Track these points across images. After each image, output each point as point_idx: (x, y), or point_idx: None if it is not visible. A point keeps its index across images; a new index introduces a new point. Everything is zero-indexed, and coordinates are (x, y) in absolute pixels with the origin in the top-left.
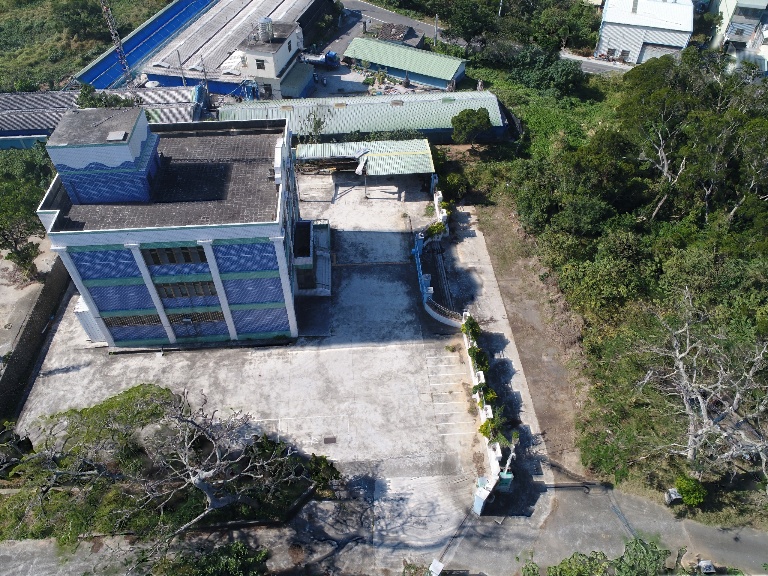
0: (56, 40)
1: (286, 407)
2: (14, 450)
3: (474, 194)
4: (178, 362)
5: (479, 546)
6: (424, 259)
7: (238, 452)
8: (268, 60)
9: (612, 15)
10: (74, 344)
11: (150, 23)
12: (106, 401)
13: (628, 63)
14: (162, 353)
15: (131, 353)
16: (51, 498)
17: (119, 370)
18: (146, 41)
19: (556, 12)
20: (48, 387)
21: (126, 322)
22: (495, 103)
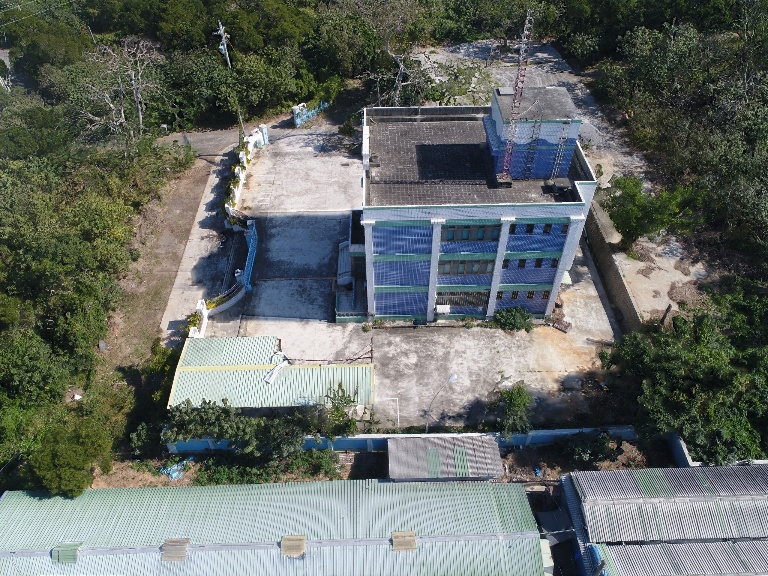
0: None
1: None
2: None
3: (137, 383)
4: None
5: (271, 135)
6: None
7: None
8: None
9: None
10: None
11: None
12: None
13: None
14: None
15: None
16: None
17: None
18: None
19: None
20: None
21: None
22: None
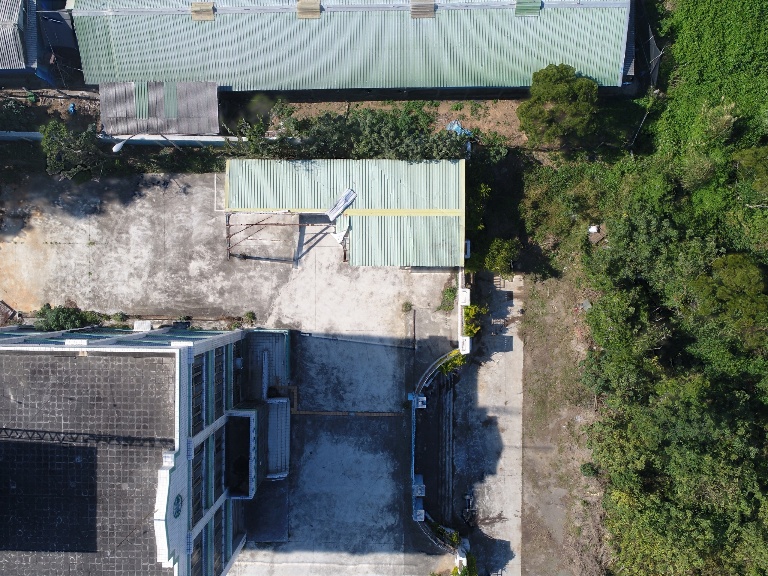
0: None
1: None
2: None
3: (529, 250)
4: None
5: None
6: (425, 410)
7: None
8: None
9: None
10: None
11: None
12: None
13: None
14: None
15: None
16: None
17: None
18: None
19: None
20: None
21: None
22: (623, 21)
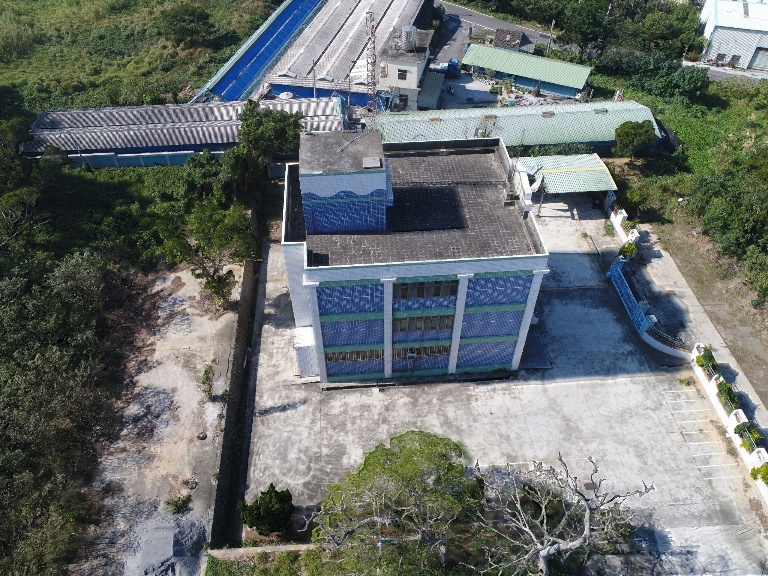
0: (162, 48)
1: (531, 449)
2: (281, 505)
3: (647, 211)
4: (399, 399)
5: None
6: None
7: (497, 500)
8: (411, 70)
9: (724, 19)
10: (282, 379)
11: (265, 30)
12: (380, 451)
13: (738, 68)
14: (378, 389)
15: (344, 389)
16: (388, 570)
17: (339, 408)
18: (264, 49)
19: (663, 16)
20: (269, 428)
21: (347, 357)
22: (649, 114)
